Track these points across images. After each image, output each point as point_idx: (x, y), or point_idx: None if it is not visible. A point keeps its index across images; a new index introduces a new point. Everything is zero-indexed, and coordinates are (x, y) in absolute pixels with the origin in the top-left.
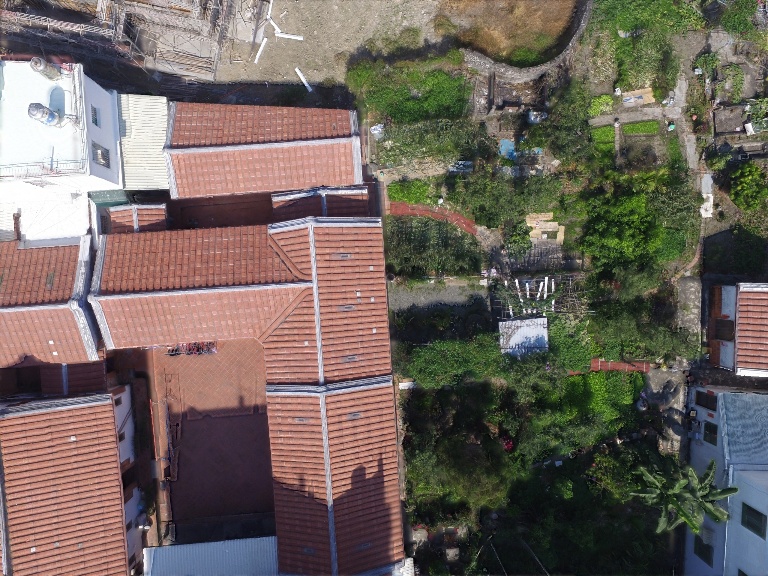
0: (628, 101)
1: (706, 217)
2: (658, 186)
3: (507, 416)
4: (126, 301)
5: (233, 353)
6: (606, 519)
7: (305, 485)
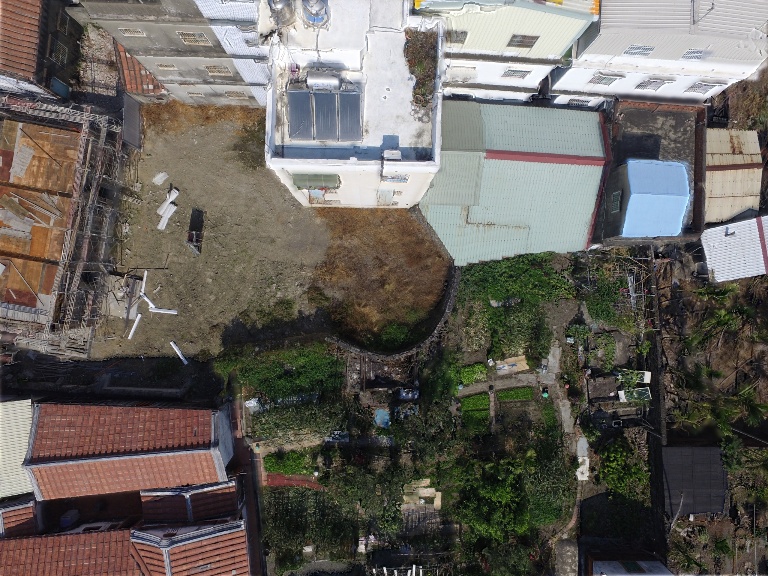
0: (502, 368)
1: (582, 480)
2: (527, 466)
3: None
4: None
5: None
6: None
7: None
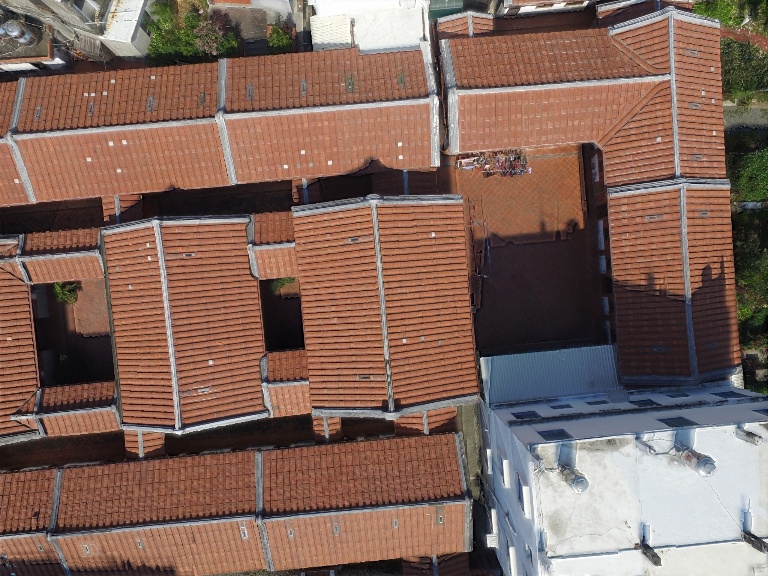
0: None
1: None
2: None
3: None
4: (482, 97)
5: (535, 179)
6: None
7: (655, 284)
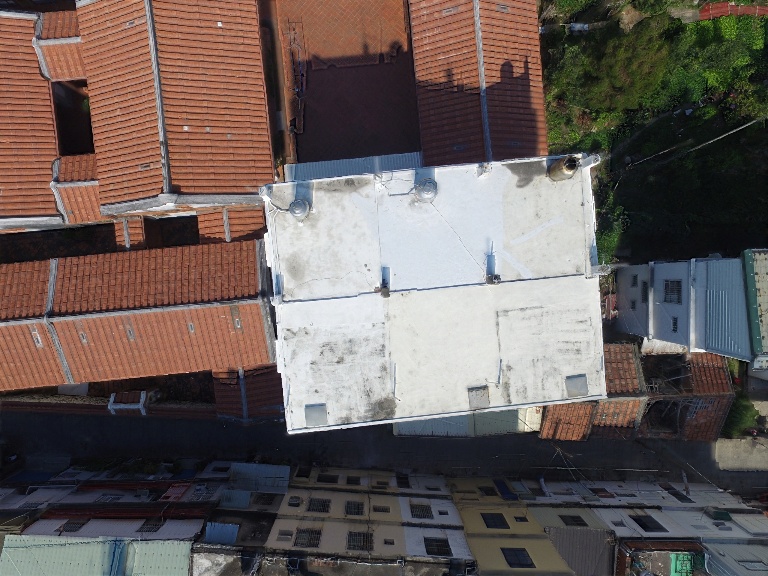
0: None
1: None
2: None
3: None
4: None
5: (357, 1)
6: (739, 165)
7: (453, 80)
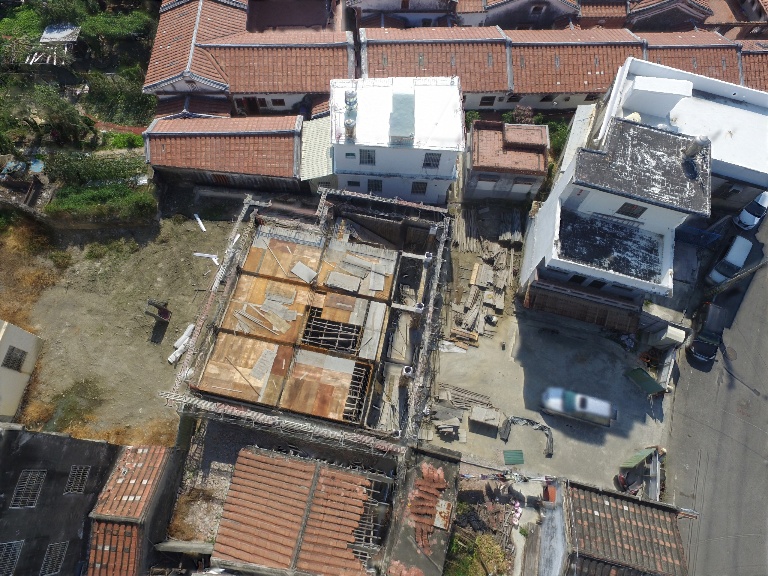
0: None
1: None
2: None
3: (94, 7)
4: None
5: None
6: None
7: None
